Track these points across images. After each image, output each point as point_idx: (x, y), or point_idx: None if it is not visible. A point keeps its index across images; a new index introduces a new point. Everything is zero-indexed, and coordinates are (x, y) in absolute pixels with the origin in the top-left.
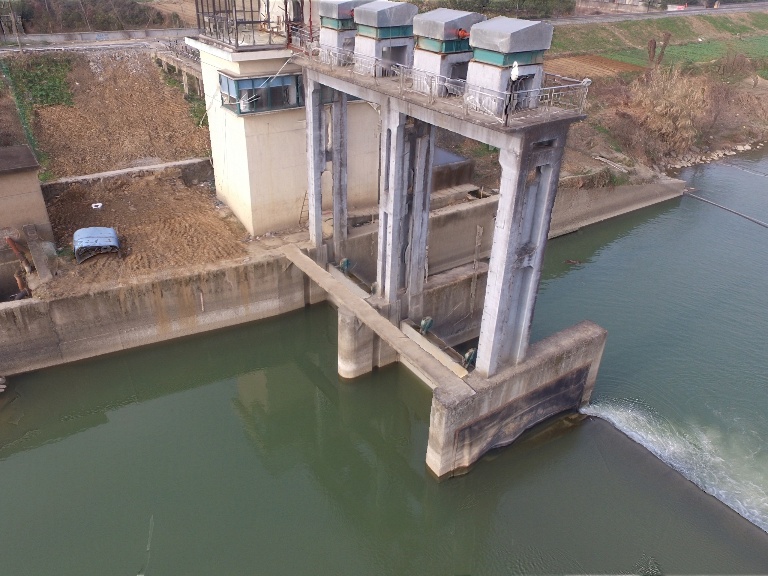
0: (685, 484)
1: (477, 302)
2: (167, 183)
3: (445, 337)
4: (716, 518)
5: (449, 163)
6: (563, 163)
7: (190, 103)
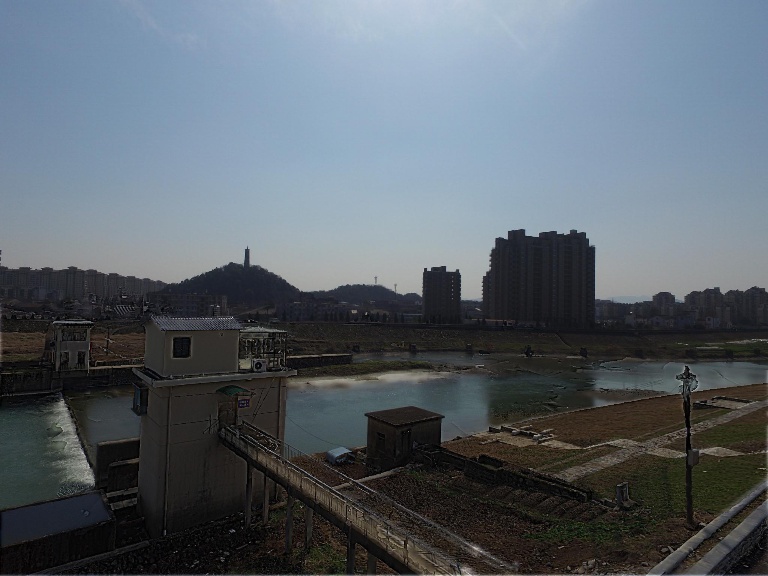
0: None
1: None
2: None
3: None
4: None
5: None
6: None
7: (359, 571)
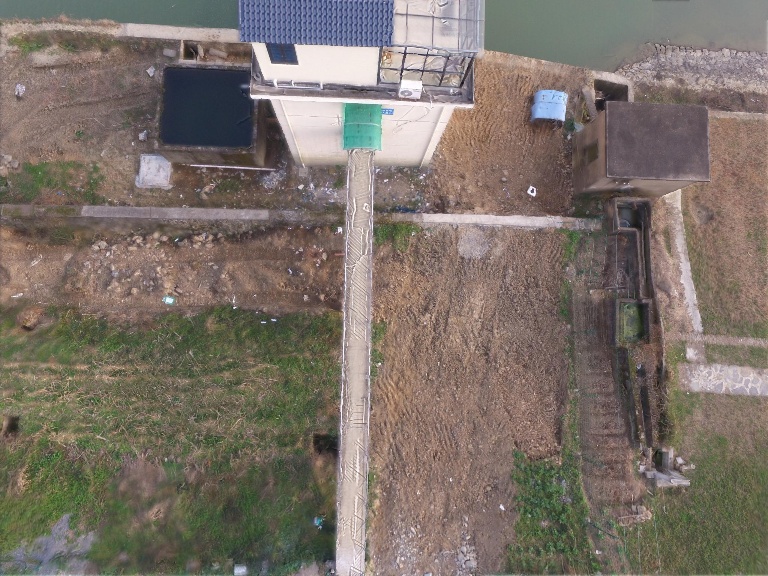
0: None
1: None
2: (463, 207)
3: None
4: None
5: (196, 67)
6: (10, 82)
7: None
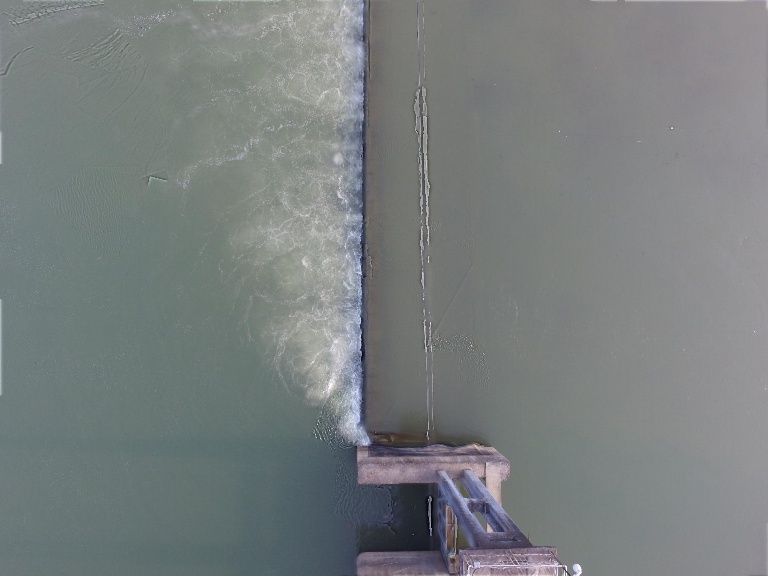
0: (372, 367)
1: (375, 571)
2: None
3: (405, 558)
4: (378, 344)
5: None
6: None
7: None
